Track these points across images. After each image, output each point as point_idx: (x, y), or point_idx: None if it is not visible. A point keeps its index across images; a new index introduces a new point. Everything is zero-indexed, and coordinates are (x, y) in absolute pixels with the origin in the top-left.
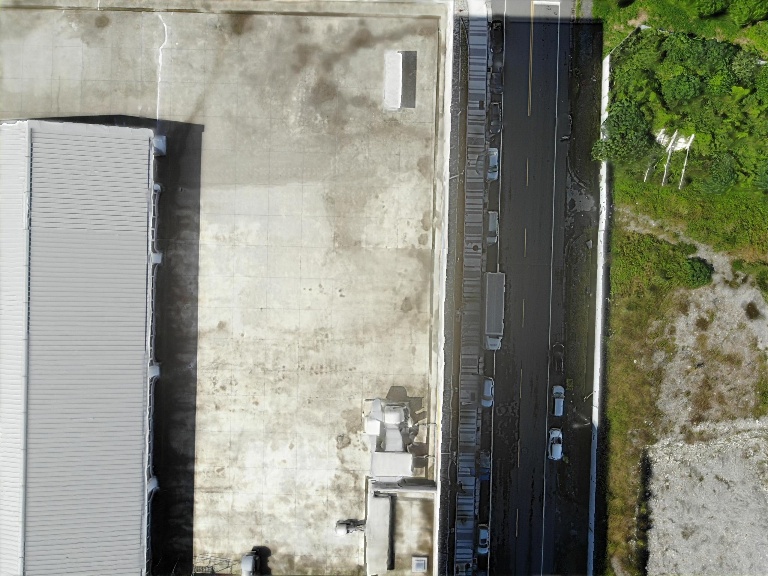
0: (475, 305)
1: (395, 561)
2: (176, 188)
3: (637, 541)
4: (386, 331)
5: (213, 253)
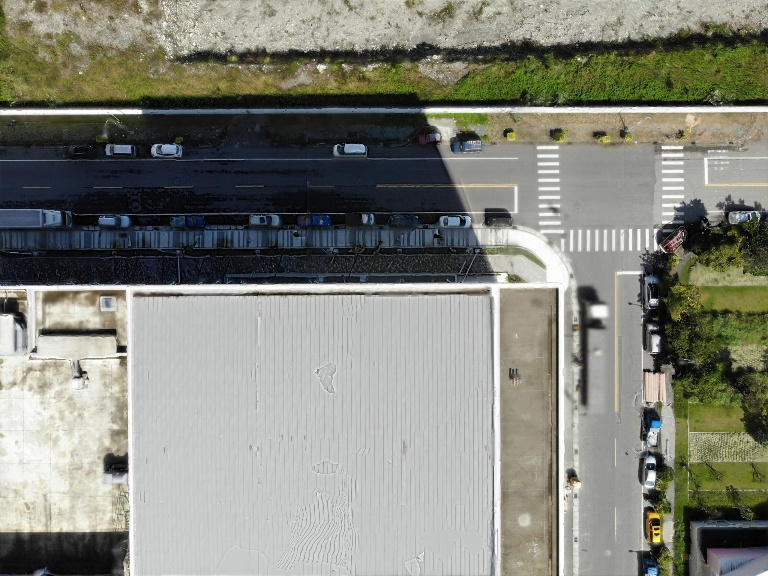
0: (30, 237)
1: (108, 329)
2: None
3: (265, 64)
4: None
5: None
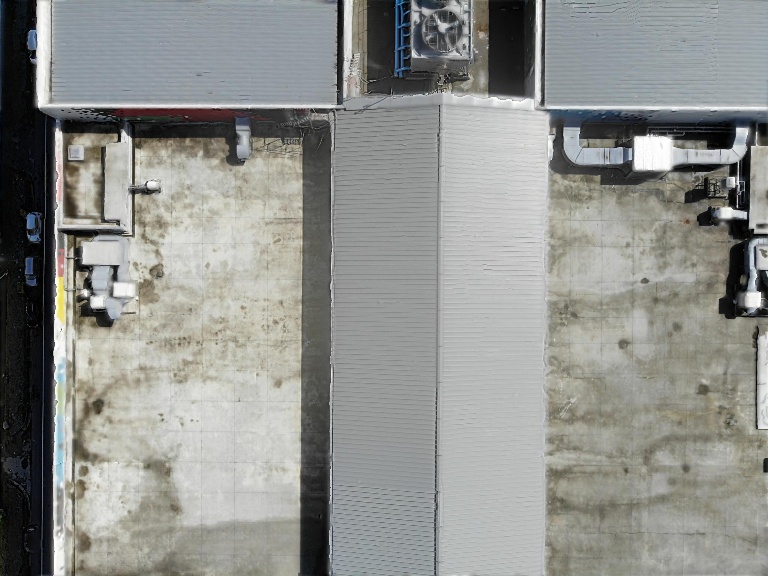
0: None
1: (102, 155)
2: (326, 518)
3: None
4: (118, 381)
5: (288, 455)
